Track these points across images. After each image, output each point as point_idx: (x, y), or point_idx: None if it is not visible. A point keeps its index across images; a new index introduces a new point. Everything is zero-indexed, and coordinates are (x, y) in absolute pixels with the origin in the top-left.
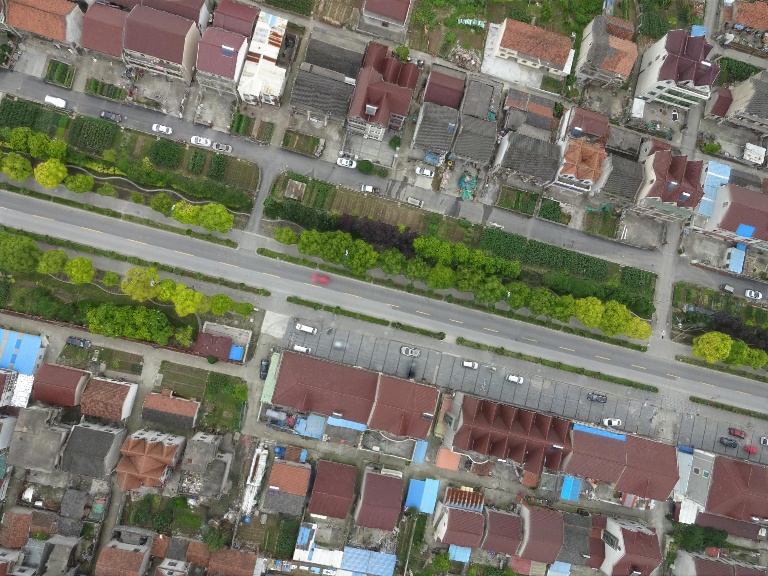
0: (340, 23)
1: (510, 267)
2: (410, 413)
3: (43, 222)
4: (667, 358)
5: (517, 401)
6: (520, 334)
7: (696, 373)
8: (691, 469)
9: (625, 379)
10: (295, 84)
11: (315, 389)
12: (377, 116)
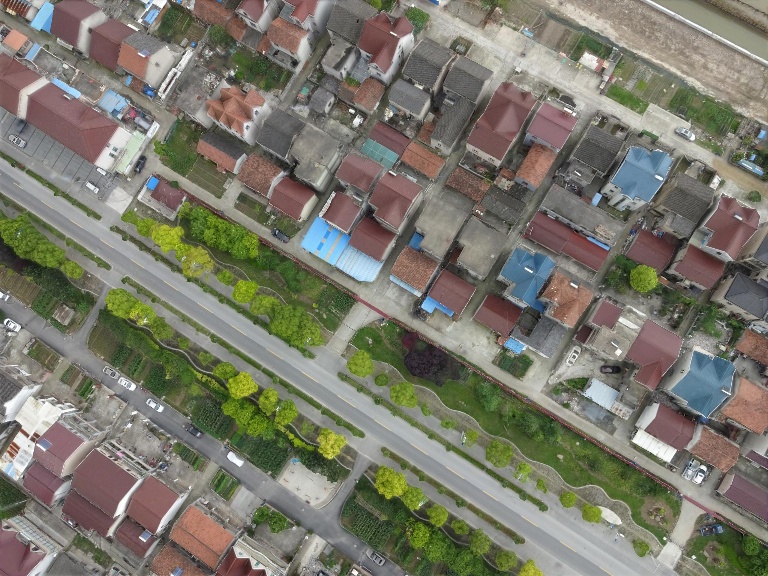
0: None
1: None
2: None
3: (276, 350)
4: None
5: None
6: None
7: None
8: None
9: None
10: (8, 401)
11: (72, 122)
12: None
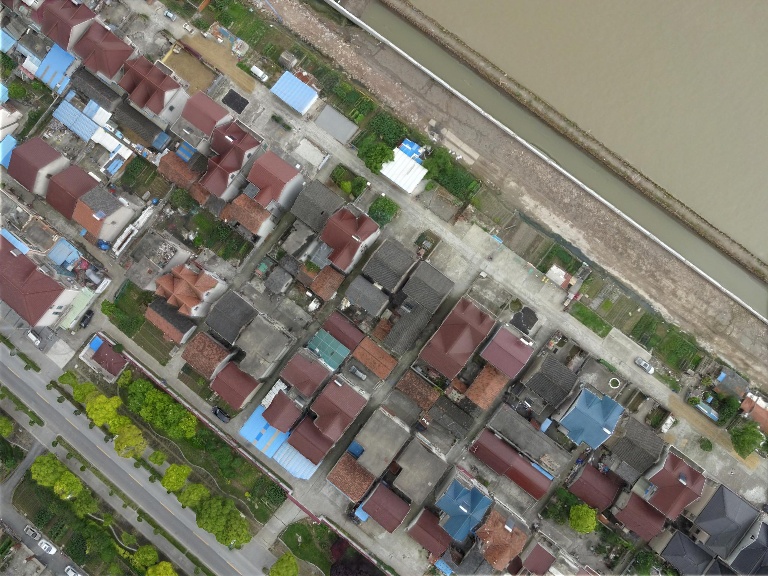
0: None
1: None
2: None
3: (203, 535)
4: None
5: None
6: None
7: None
8: None
9: None
10: None
11: (15, 283)
12: None
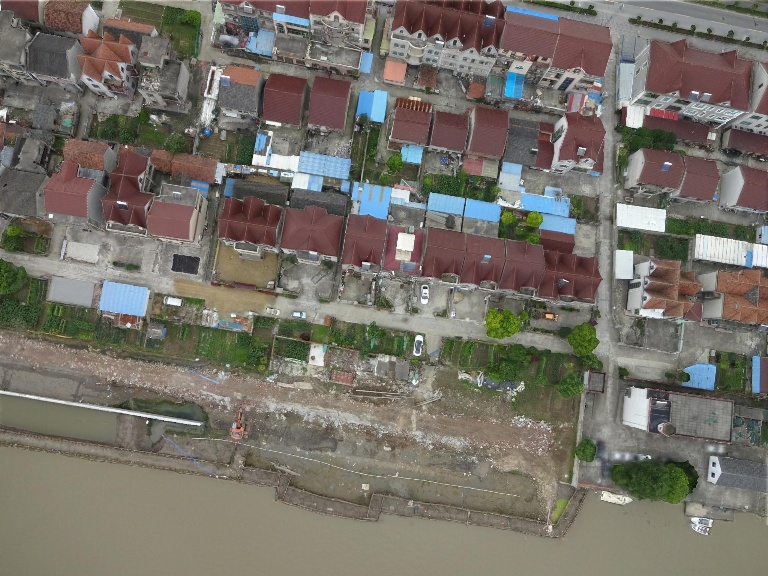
0: None
1: None
2: None
3: None
4: None
5: None
6: None
7: None
8: (634, 75)
9: (563, 4)
10: None
11: None
12: None
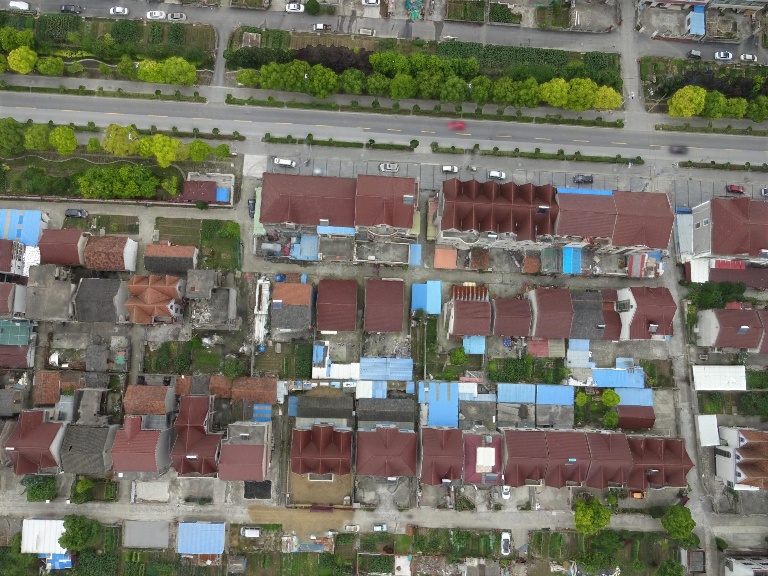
0: None
1: (468, 64)
2: (391, 200)
3: (26, 112)
4: (647, 130)
5: None
6: (493, 133)
7: (680, 139)
8: (693, 227)
9: (608, 157)
10: None
11: (297, 198)
12: None
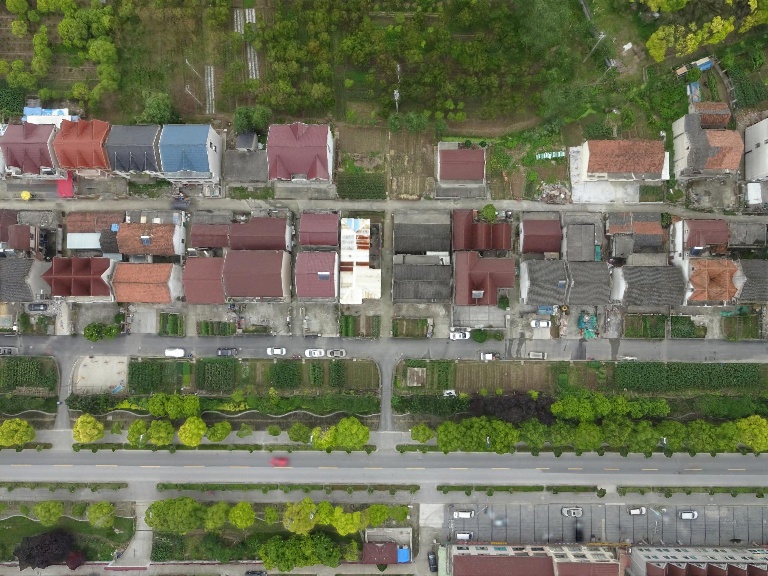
0: (418, 197)
1: (658, 408)
2: None
3: (195, 471)
4: None
5: (696, 536)
6: (682, 466)
7: None
8: None
9: None
10: (394, 284)
11: None
12: (485, 299)
